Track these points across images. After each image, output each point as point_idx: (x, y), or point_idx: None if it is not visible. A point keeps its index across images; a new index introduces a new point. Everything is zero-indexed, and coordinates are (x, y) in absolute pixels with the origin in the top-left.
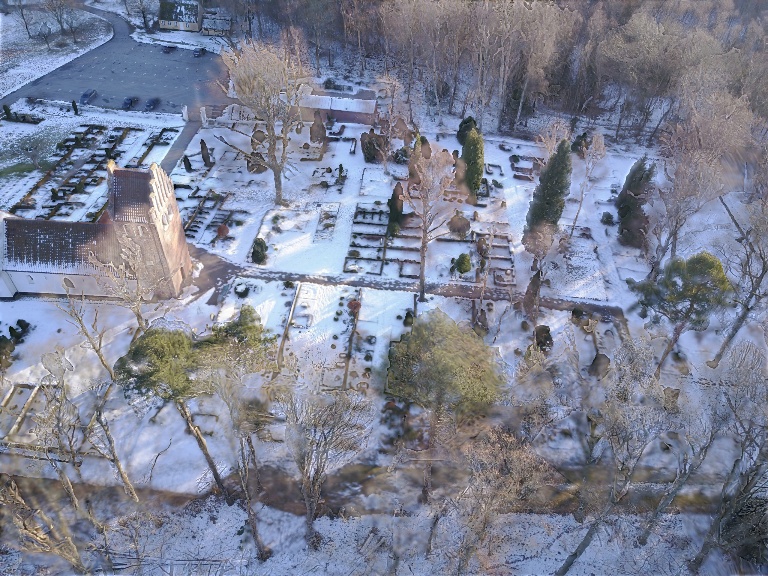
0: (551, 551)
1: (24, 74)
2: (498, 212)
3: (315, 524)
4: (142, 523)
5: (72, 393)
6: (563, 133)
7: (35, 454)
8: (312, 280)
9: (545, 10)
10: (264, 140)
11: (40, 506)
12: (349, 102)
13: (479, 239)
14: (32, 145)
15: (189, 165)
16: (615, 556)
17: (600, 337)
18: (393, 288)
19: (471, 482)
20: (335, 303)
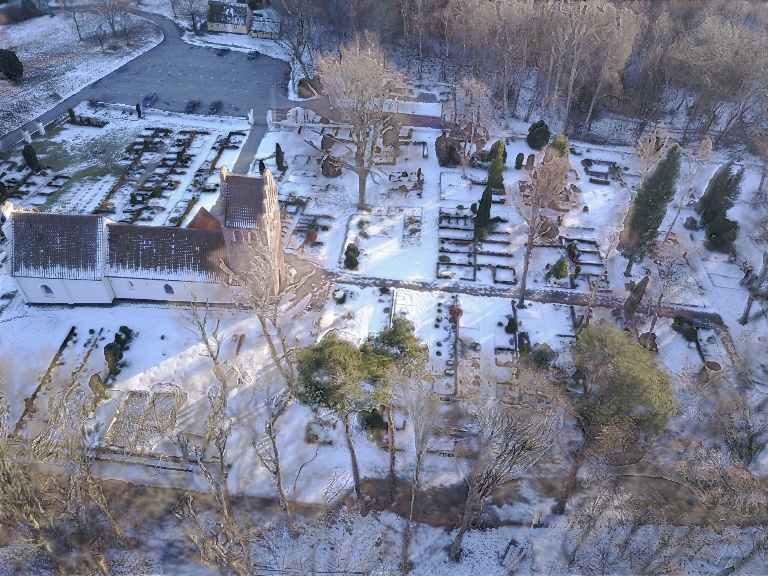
0: (694, 563)
1: (82, 77)
2: (581, 217)
3: (452, 535)
4: (278, 534)
5: None
6: (627, 136)
7: (157, 463)
8: (407, 286)
9: (624, 13)
10: (333, 144)
11: (171, 516)
12: (415, 105)
13: (570, 244)
14: (100, 149)
15: None
16: (759, 569)
17: (703, 344)
18: (489, 294)
19: (601, 492)
20: (433, 309)
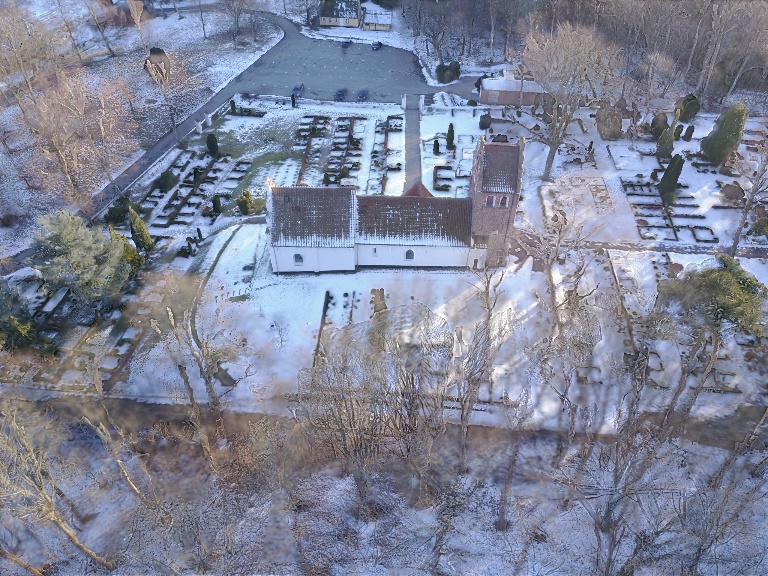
0: None
1: (225, 72)
2: None
3: (748, 457)
4: None
5: (457, 351)
6: (759, 109)
7: (453, 404)
8: (617, 247)
9: None
10: (490, 124)
11: (485, 448)
12: None
13: (758, 205)
14: (269, 136)
15: (438, 148)
16: None
17: None
18: (695, 252)
19: None
20: (649, 267)
